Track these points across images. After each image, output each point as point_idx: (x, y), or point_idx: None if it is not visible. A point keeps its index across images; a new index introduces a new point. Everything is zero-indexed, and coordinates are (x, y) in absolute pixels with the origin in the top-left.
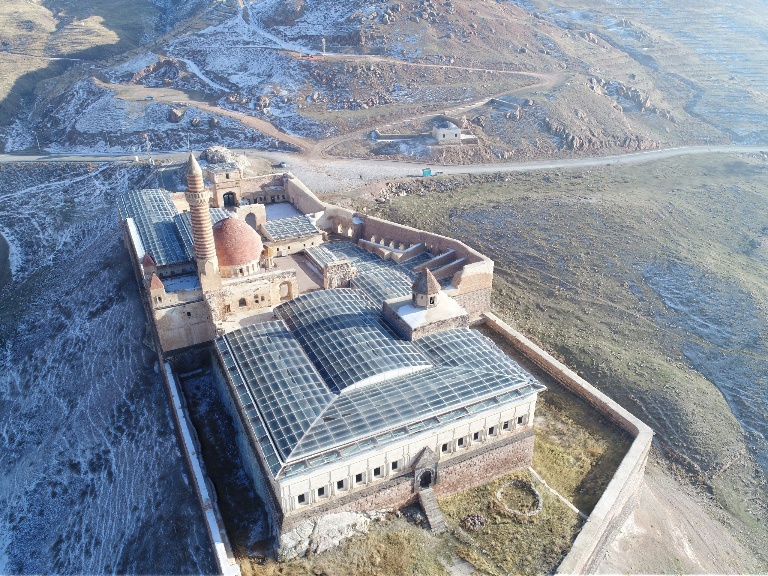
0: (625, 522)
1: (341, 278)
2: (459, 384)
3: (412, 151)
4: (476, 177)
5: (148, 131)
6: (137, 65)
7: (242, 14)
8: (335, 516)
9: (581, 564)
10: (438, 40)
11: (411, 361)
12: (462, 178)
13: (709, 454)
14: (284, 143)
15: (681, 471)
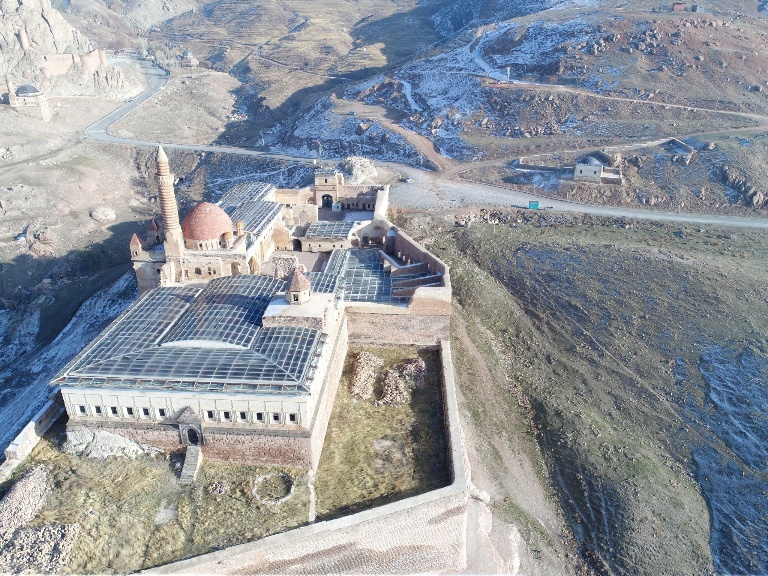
0: (418, 573)
1: (287, 271)
2: (242, 366)
3: (543, 183)
4: (592, 218)
5: (337, 140)
6: (367, 85)
7: (472, 43)
8: (110, 435)
9: (258, 556)
10: (645, 73)
11: (233, 339)
12: (573, 217)
13: (638, 573)
14: (428, 162)
15: (591, 575)
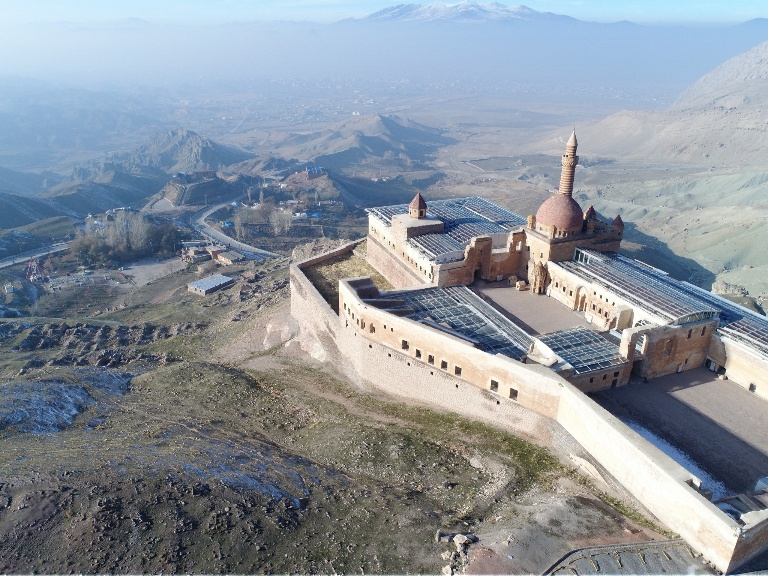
0: None
1: (478, 248)
2: None
3: None
4: None
5: None
6: None
7: None
8: None
9: None
10: None
11: None
12: None
13: None
14: None
15: None
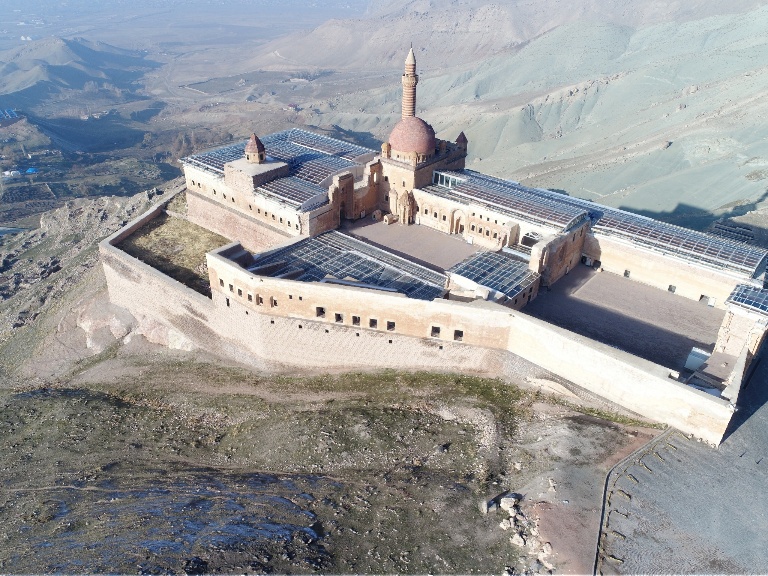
0: None
1: (340, 187)
2: None
3: None
4: None
5: None
6: None
7: None
8: None
9: None
10: None
11: None
12: None
13: None
14: None
15: None
